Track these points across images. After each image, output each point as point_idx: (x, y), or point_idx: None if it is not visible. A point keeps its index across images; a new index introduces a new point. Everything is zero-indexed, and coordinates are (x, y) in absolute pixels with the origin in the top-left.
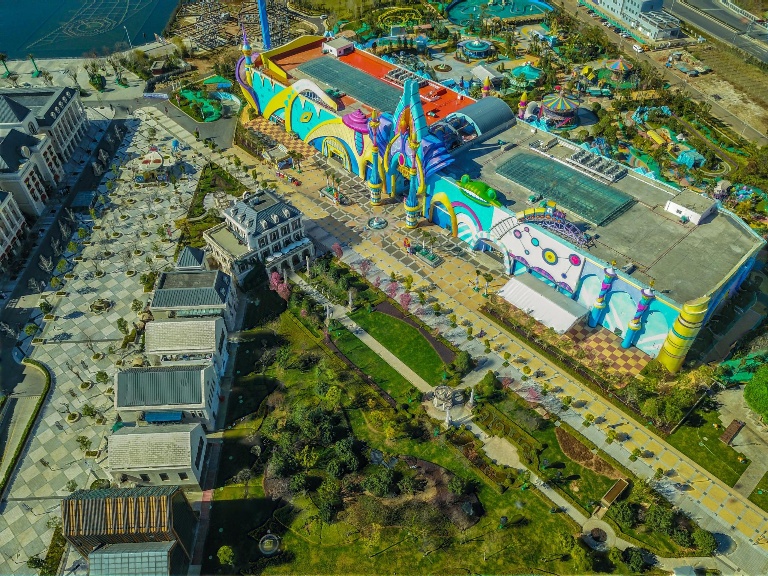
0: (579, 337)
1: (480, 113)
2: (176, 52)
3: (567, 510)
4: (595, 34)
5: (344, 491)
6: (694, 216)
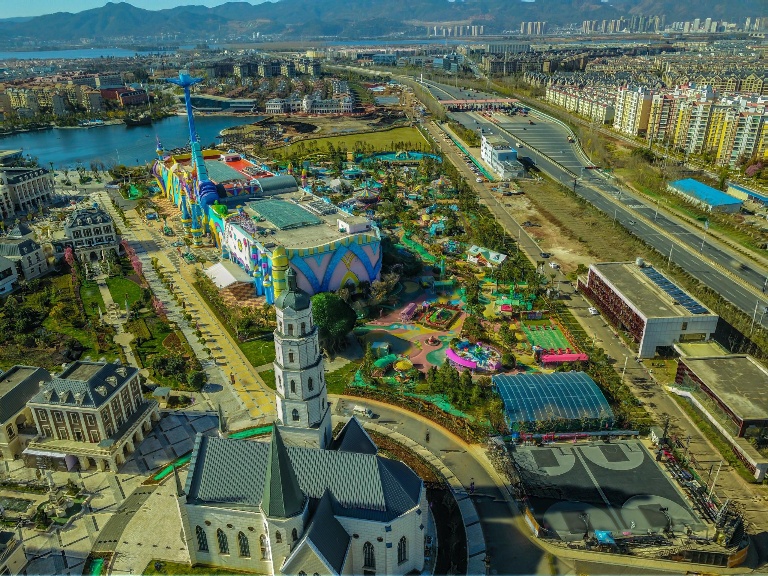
0: (242, 298)
1: (268, 180)
2: (147, 168)
3: (131, 365)
4: (444, 168)
5: (5, 343)
6: (347, 227)
